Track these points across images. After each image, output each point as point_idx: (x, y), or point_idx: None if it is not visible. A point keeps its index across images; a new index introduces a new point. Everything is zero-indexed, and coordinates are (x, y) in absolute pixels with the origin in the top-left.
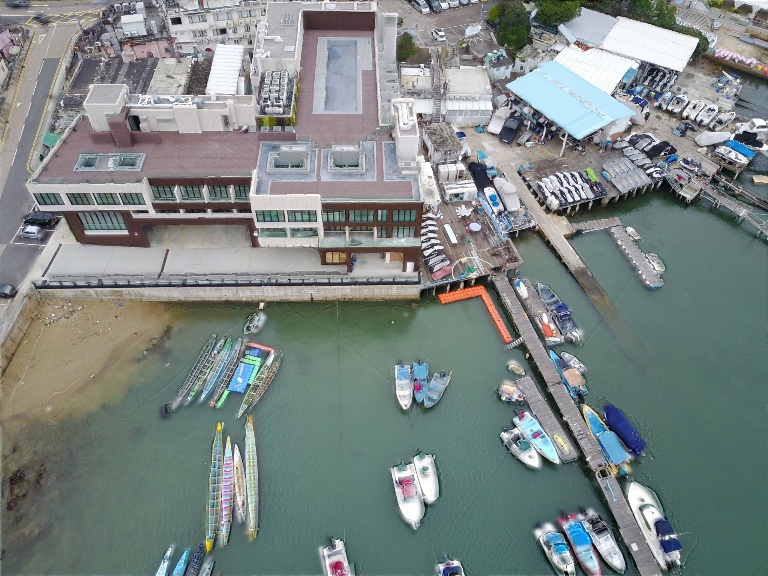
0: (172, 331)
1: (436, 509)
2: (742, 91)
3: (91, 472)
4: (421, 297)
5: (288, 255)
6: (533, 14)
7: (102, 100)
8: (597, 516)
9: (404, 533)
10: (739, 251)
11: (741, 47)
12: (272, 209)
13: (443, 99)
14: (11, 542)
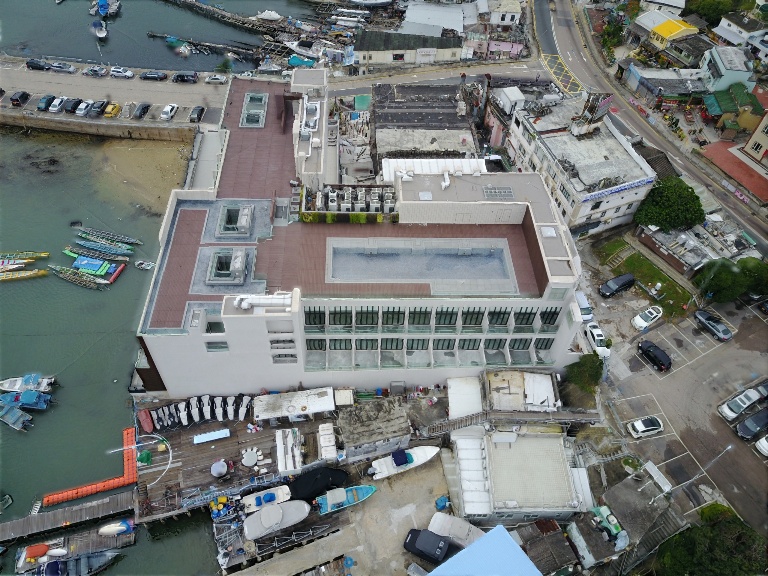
0: (155, 218)
1: None
2: None
3: (42, 194)
4: None
5: None
6: None
7: (300, 77)
8: None
9: None
10: None
11: None
12: None
13: None
14: (8, 169)
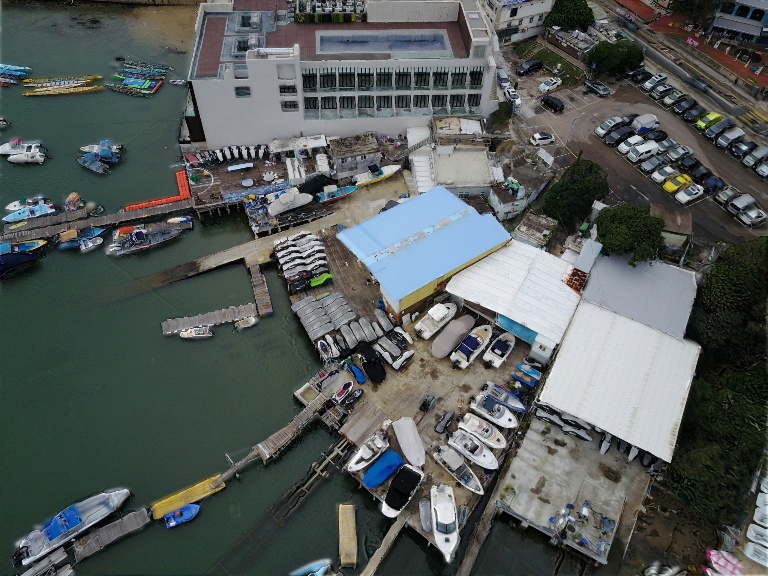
0: (181, 54)
1: (2, 161)
2: None
3: (90, 42)
4: None
5: None
6: (601, 207)
7: None
8: None
9: None
10: None
11: None
12: None
13: None
14: None
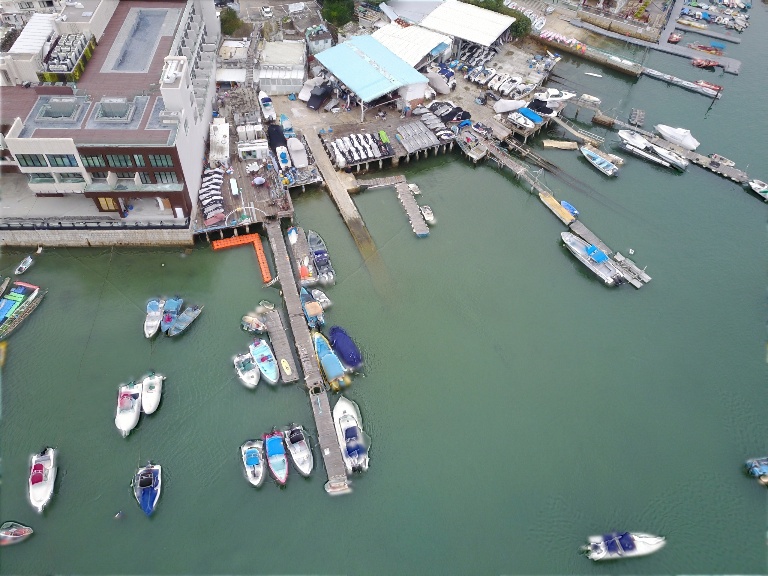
0: None
1: (151, 421)
2: (559, 68)
3: None
4: (195, 243)
5: (70, 204)
6: None
7: None
8: (301, 426)
9: (113, 442)
10: (519, 207)
11: (569, 30)
12: (31, 153)
13: (259, 69)
14: None
